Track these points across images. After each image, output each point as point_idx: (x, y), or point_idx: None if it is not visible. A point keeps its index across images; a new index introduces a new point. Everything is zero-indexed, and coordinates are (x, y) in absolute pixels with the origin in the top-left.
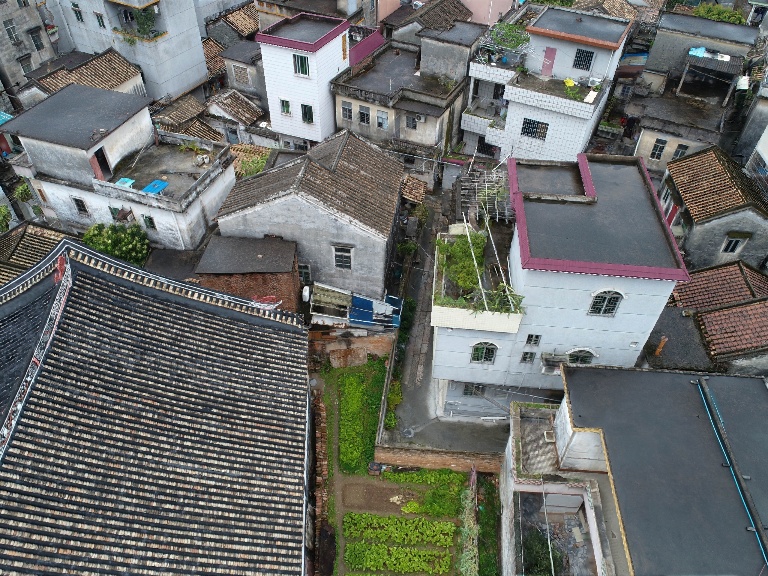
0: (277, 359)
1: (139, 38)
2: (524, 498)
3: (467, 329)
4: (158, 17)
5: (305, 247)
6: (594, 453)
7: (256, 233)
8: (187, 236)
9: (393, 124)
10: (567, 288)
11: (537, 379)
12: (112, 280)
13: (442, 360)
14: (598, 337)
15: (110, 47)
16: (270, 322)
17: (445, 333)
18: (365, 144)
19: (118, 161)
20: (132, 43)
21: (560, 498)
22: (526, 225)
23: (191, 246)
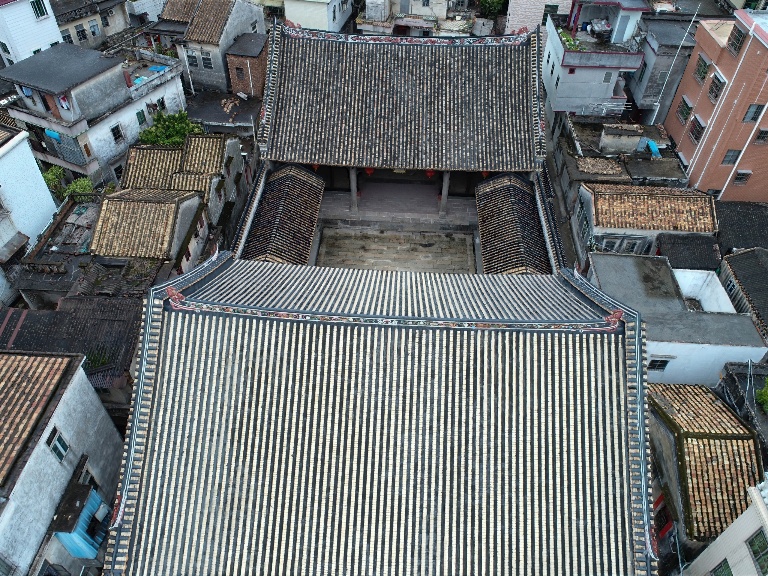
0: None
1: None
2: None
3: None
4: None
5: None
6: None
7: None
8: (183, 96)
9: (102, 26)
10: None
11: None
12: None
13: None
14: None
15: None
16: None
17: None
18: None
19: None
20: None
21: None
22: None
23: (186, 104)
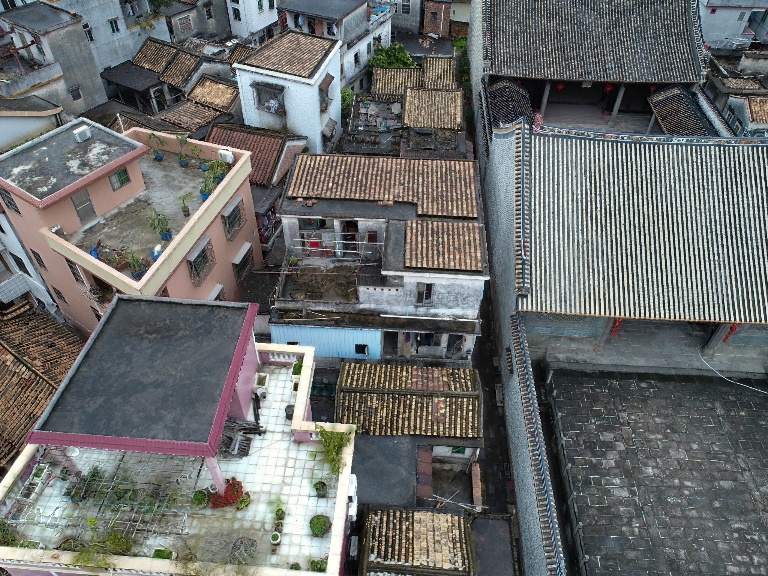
0: None
1: (155, 18)
2: None
3: None
4: (141, 0)
5: None
6: None
7: None
8: (390, 34)
9: None
10: None
11: None
12: None
13: None
14: None
15: (148, 37)
16: None
17: None
18: None
19: None
20: (153, 26)
21: None
22: None
23: None
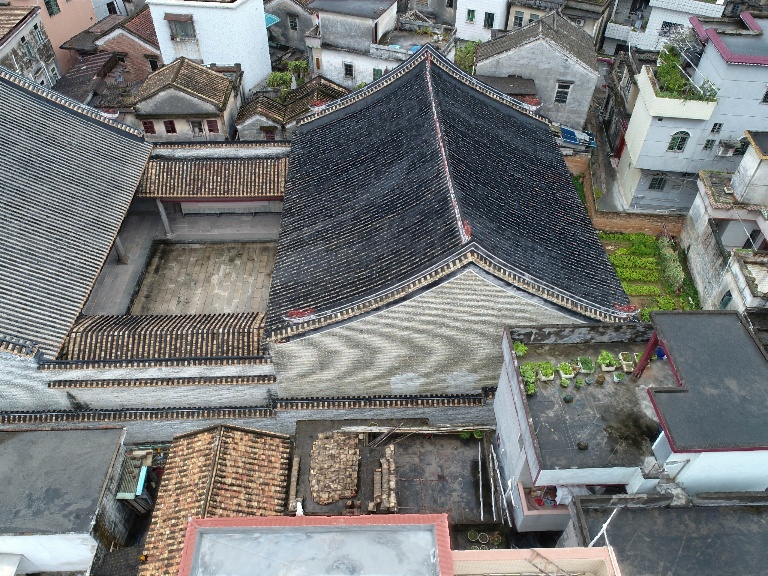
0: (541, 141)
1: None
2: (715, 223)
3: (674, 118)
4: None
5: (536, 85)
6: (767, 187)
7: (503, 74)
8: None
9: None
10: (751, 81)
11: (711, 165)
12: (445, 78)
13: (647, 150)
14: (763, 124)
15: None
16: (531, 120)
17: (656, 124)
18: (567, 22)
19: (381, 36)
20: None
21: (731, 238)
22: (722, 42)
23: None
